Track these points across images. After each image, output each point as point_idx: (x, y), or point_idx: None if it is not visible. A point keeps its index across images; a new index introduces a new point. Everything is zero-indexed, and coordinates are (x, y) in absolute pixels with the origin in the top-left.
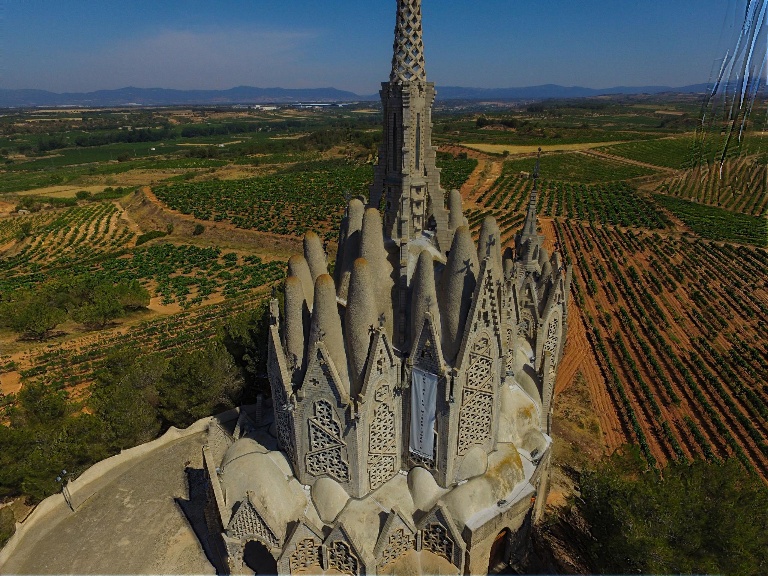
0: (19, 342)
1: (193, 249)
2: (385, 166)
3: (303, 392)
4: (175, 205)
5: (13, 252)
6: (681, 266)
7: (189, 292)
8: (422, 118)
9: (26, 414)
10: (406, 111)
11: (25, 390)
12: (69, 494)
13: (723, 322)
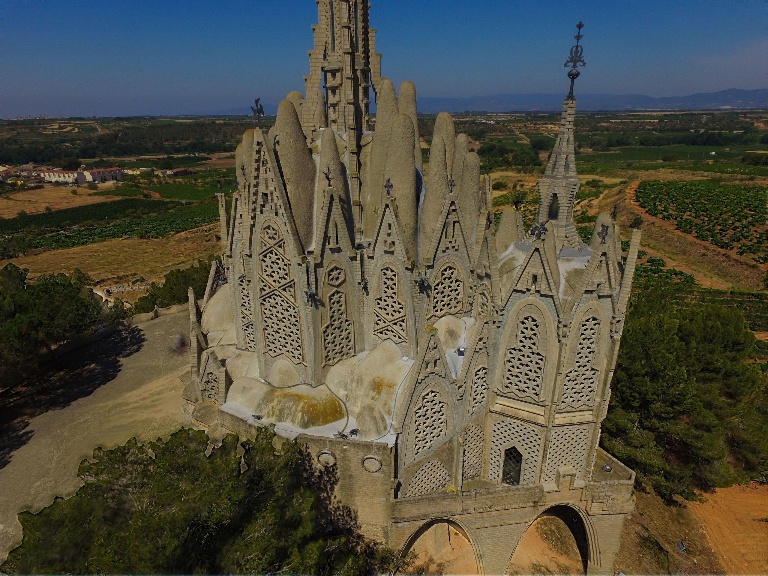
0: None
1: None
2: None
3: None
4: (642, 198)
5: None
6: None
7: None
8: None
9: None
10: None
11: None
12: None
13: None
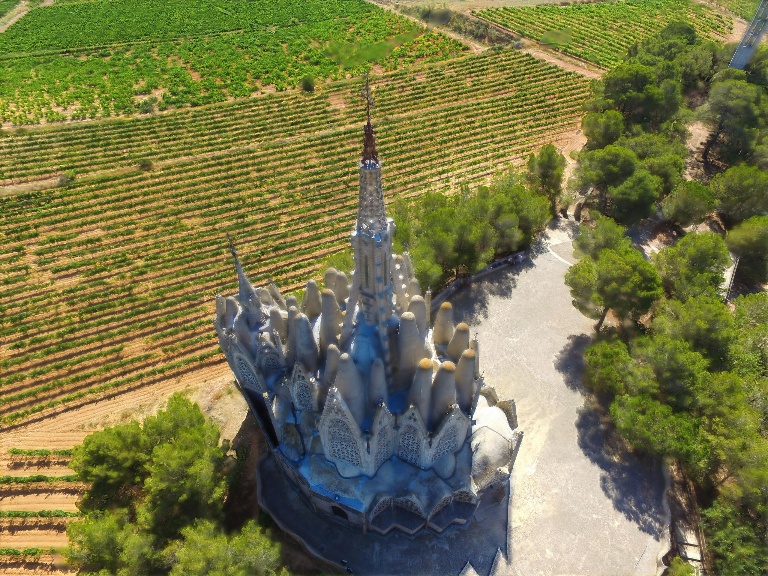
0: None
1: None
2: None
3: None
4: None
5: None
6: None
7: None
8: None
9: None
10: None
11: None
12: None
13: None
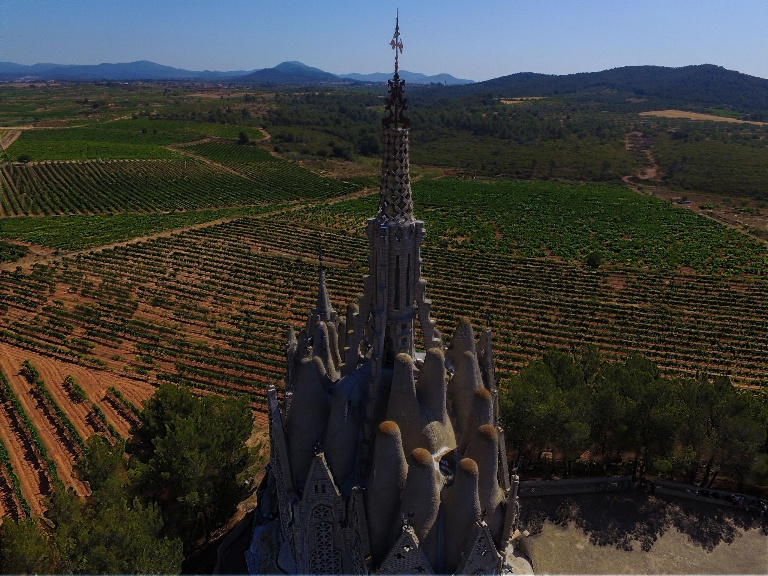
0: None
1: None
2: (387, 308)
3: None
4: None
5: None
6: (105, 284)
7: None
8: None
9: None
10: None
11: None
12: None
13: (203, 310)
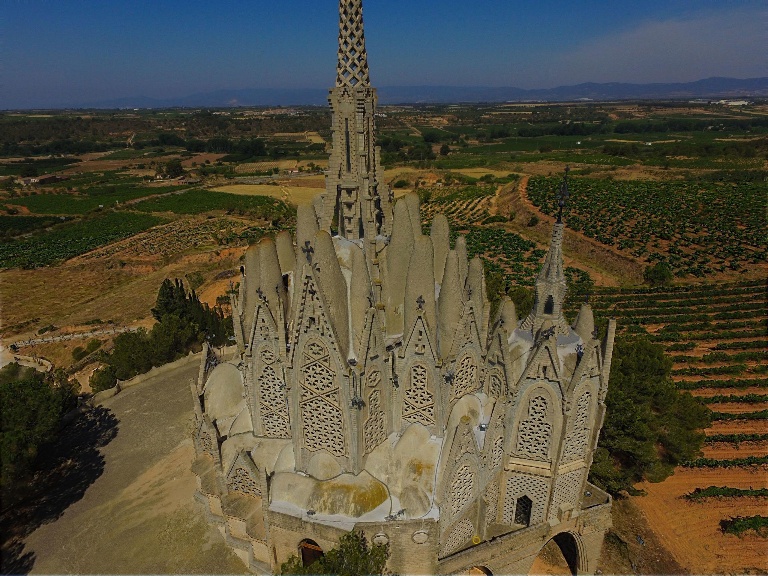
0: None
1: (515, 238)
2: None
3: None
4: (533, 196)
5: None
6: None
7: None
8: (351, 123)
9: None
10: (333, 116)
11: None
12: (224, 353)
13: None
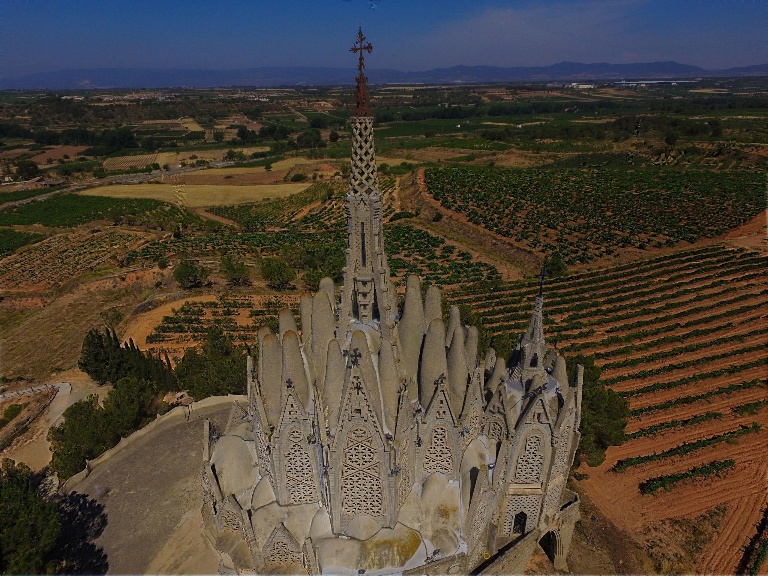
0: (267, 287)
1: (424, 235)
2: None
3: (250, 411)
4: (433, 190)
5: (315, 210)
6: None
7: (396, 275)
8: (367, 226)
9: (210, 346)
10: (350, 220)
11: (210, 332)
12: (192, 409)
13: None
